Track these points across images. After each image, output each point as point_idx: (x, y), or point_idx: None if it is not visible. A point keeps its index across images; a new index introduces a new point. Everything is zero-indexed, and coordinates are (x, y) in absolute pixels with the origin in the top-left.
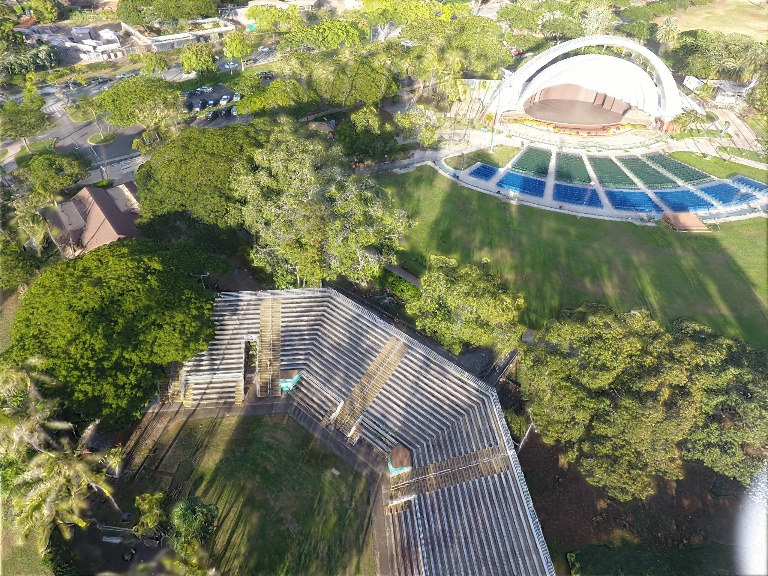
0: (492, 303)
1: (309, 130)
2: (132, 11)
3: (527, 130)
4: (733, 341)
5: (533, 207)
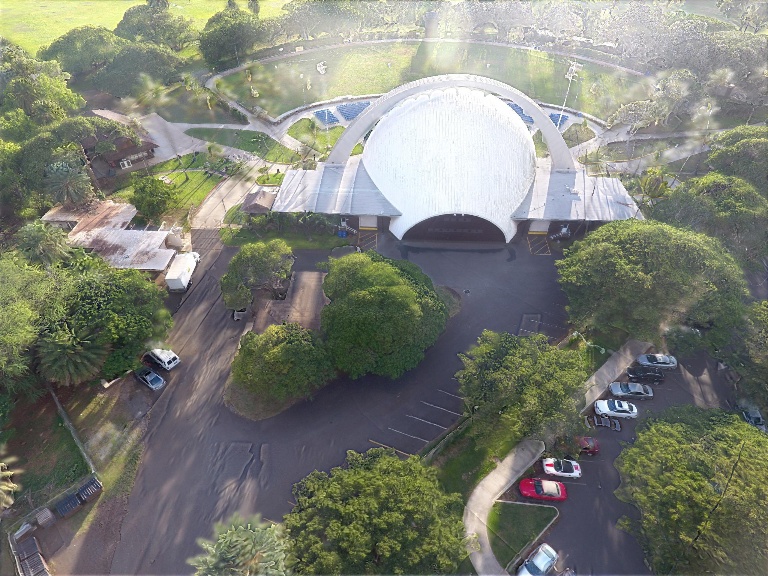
0: None
1: None
2: None
3: None
4: (470, 10)
5: None
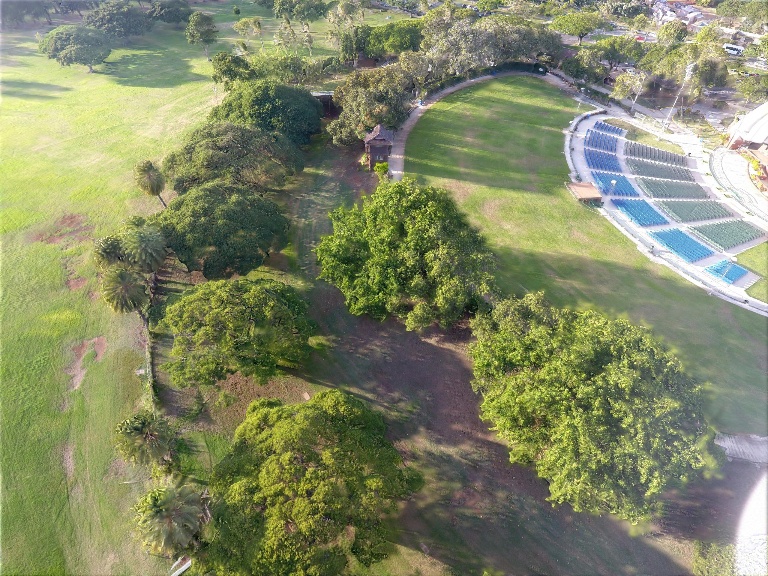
0: (404, 57)
1: (541, 35)
2: (726, 4)
3: (736, 164)
4: None
5: (564, 138)
